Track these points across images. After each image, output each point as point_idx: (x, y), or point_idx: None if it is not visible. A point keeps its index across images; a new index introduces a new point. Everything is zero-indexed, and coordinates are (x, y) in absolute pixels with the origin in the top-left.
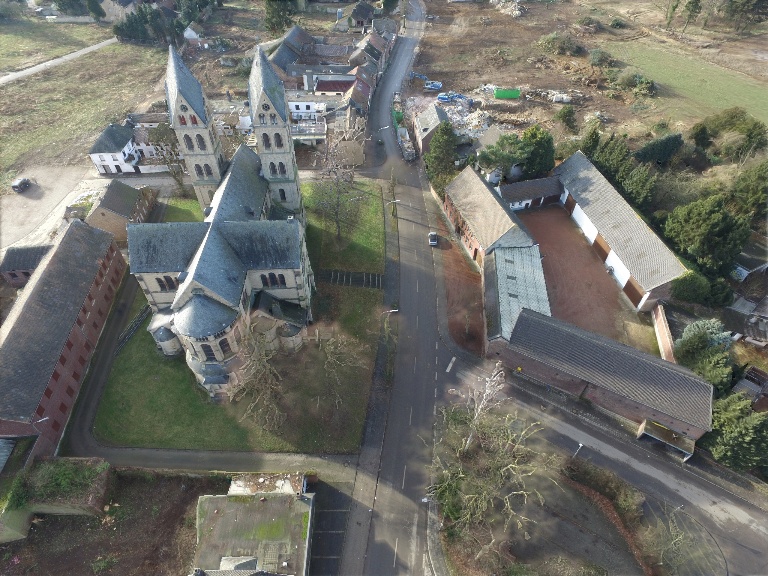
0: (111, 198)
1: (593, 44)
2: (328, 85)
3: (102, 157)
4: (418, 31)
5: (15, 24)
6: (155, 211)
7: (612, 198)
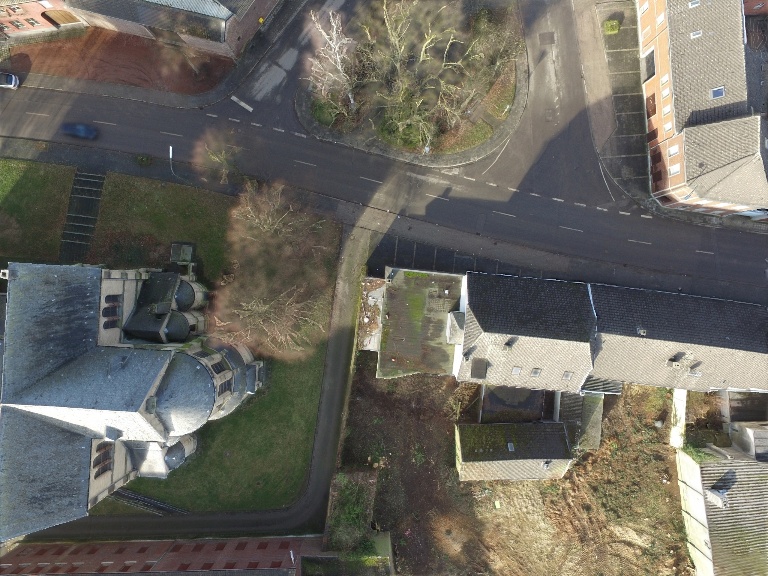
0: None
1: None
2: None
3: None
4: None
5: None
6: None
7: None
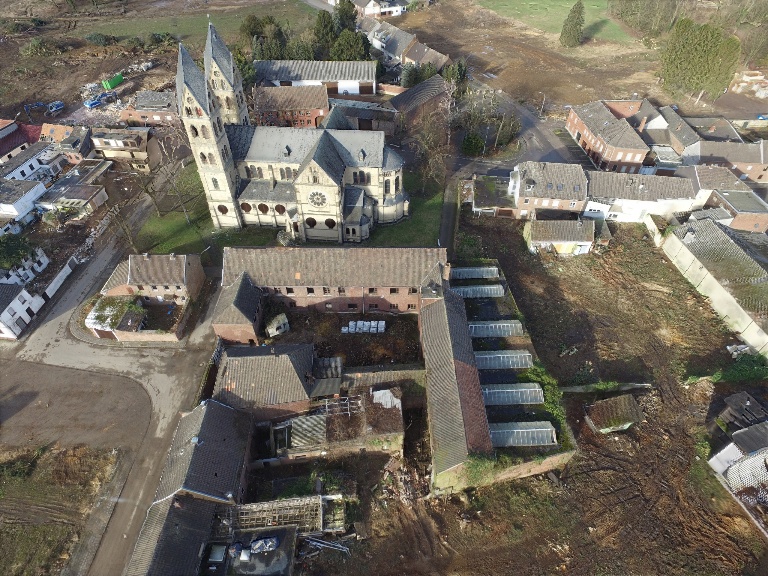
0: None
1: (63, 38)
2: (2, 146)
3: (10, 311)
4: None
5: None
6: None
7: (308, 64)
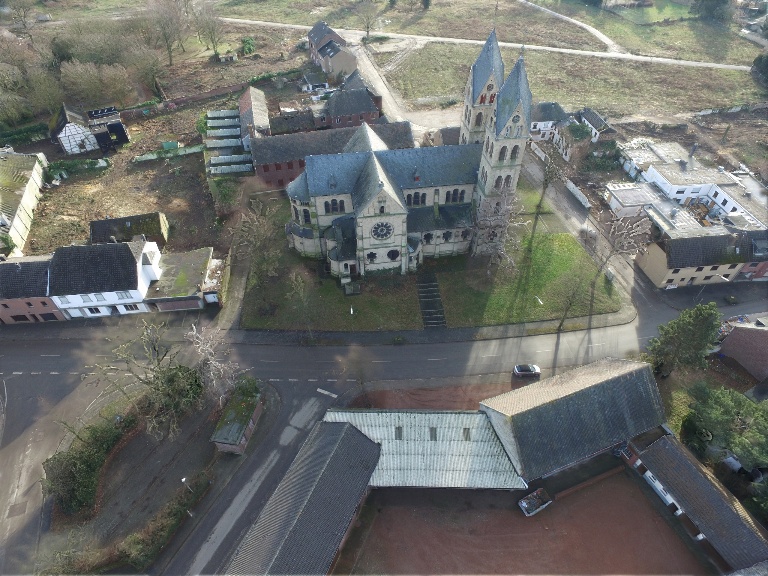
0: (455, 132)
1: None
2: None
3: None
4: None
5: (714, 26)
6: None
7: None
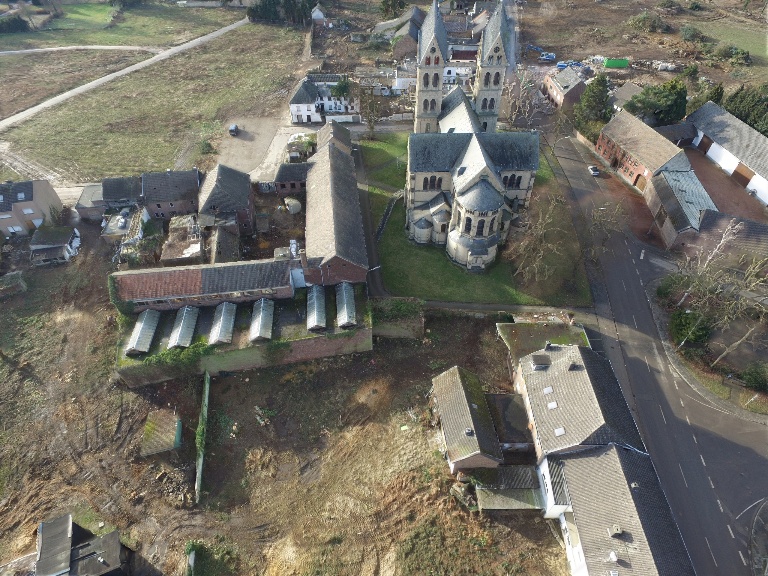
0: (337, 133)
1: (679, 23)
2: (462, 54)
3: (299, 108)
4: (512, 14)
5: (151, 8)
6: (353, 150)
7: (751, 135)
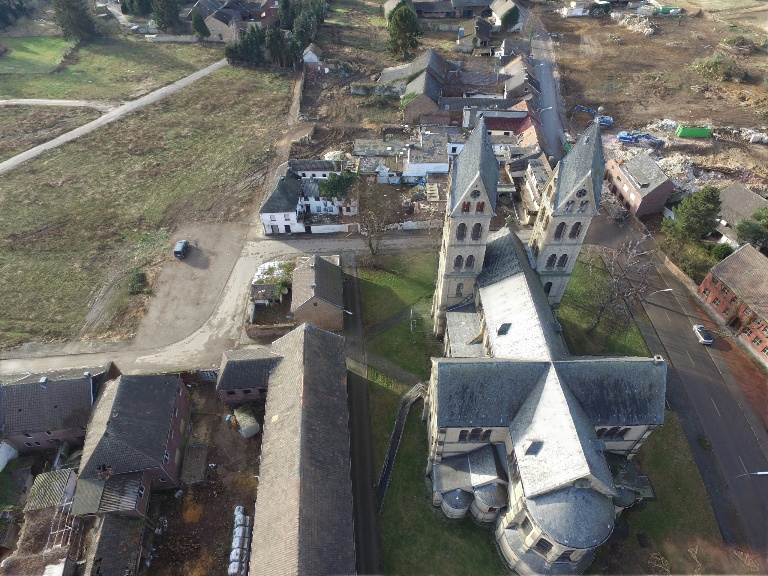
0: (321, 283)
1: (756, 68)
2: (494, 123)
3: (273, 216)
4: (547, 52)
5: (113, 44)
6: (347, 287)
7: None
